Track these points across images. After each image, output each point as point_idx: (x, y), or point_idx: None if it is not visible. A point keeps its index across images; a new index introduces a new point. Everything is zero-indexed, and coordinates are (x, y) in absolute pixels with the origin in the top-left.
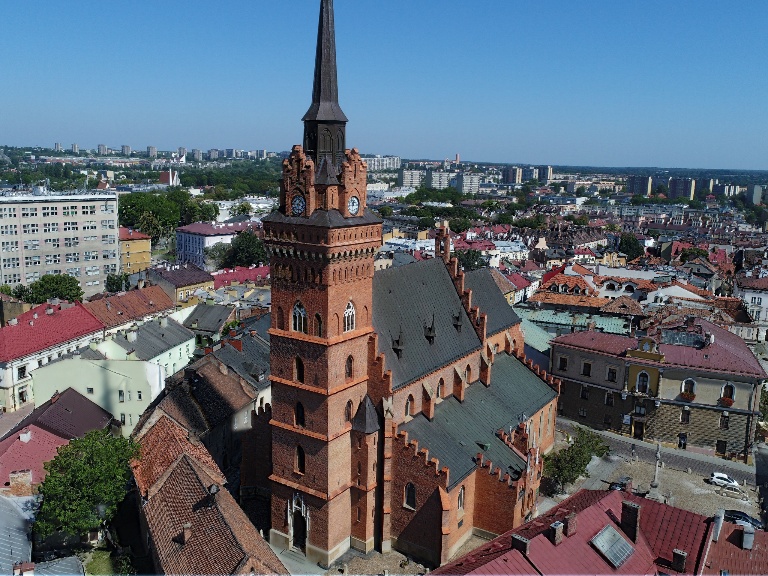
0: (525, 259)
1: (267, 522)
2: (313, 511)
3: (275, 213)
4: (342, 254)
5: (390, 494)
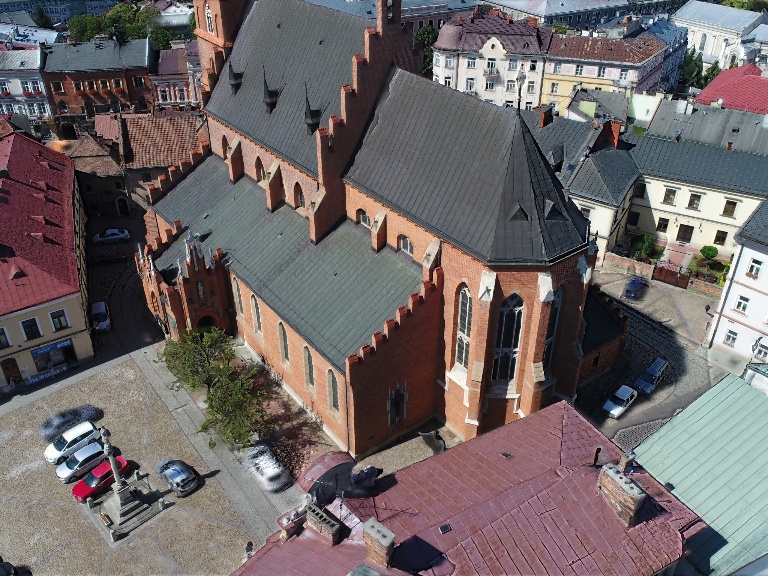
0: None
1: None
2: None
3: None
4: None
5: None
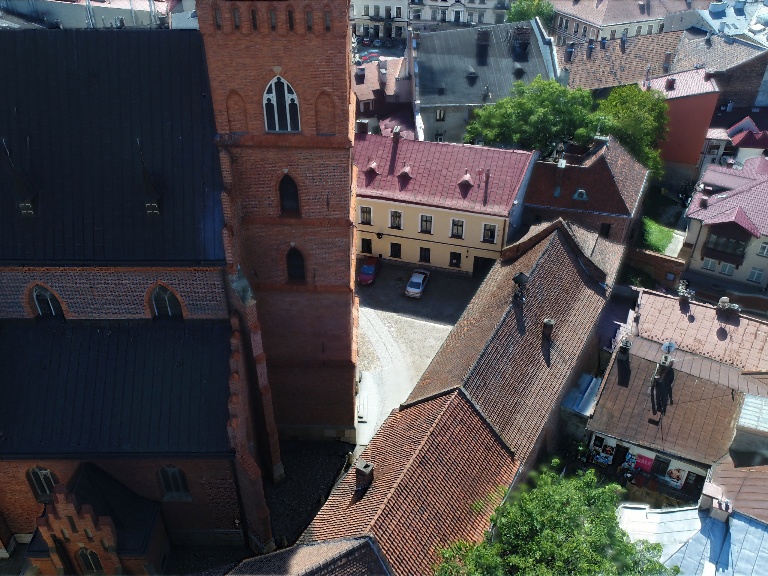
0: None
1: (313, 479)
2: None
3: None
4: None
5: None
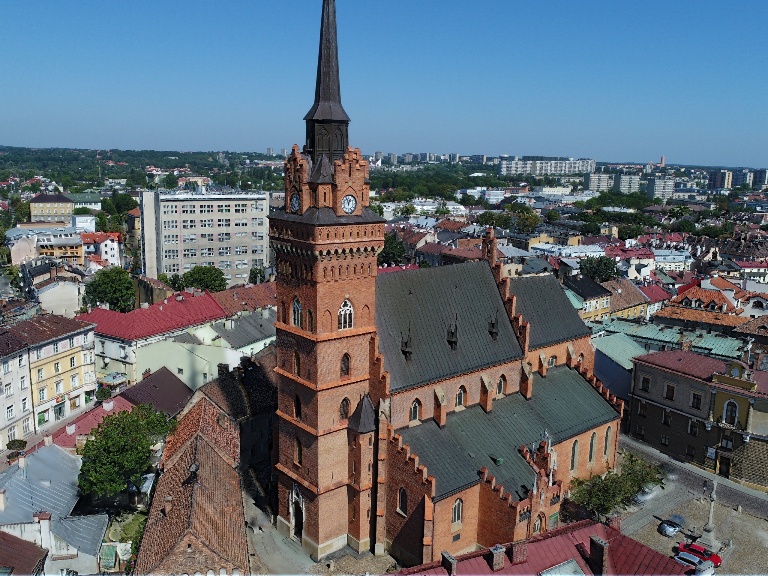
0: (683, 270)
1: None
2: (307, 503)
3: (279, 210)
4: (332, 252)
5: (384, 497)
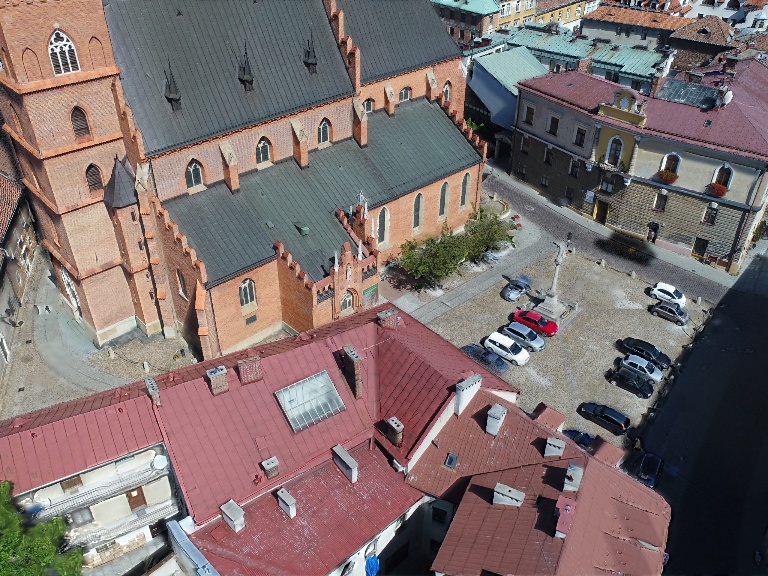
0: None
1: None
2: (76, 287)
3: None
4: None
5: (162, 278)
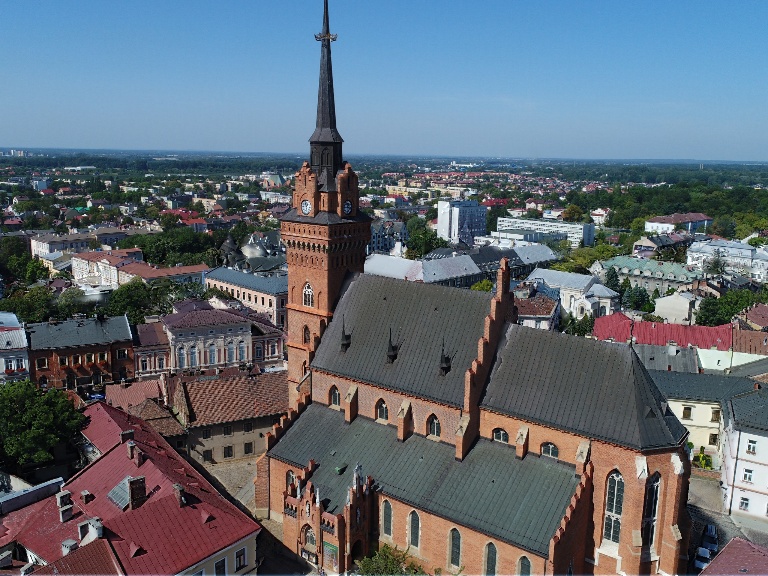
0: None
1: None
2: None
3: None
4: (292, 242)
5: None
